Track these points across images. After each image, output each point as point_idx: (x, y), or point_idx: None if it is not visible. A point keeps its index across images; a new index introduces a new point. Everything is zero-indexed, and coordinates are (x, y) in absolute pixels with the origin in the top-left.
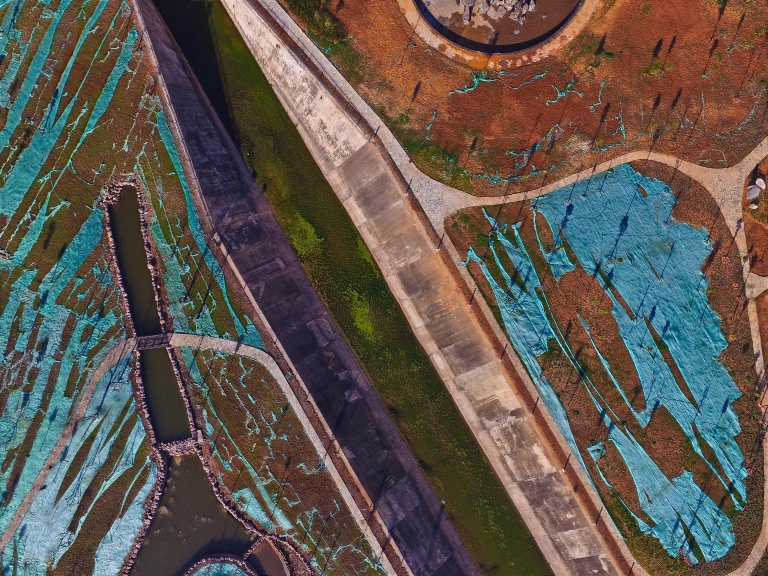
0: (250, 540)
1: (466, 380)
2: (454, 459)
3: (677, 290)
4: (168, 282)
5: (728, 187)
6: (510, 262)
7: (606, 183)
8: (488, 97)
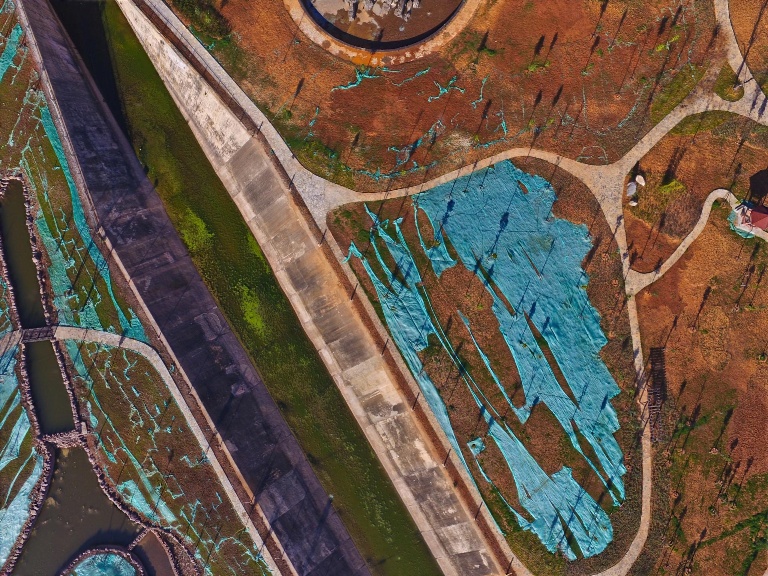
0: (136, 532)
1: (352, 375)
2: (342, 453)
3: (557, 286)
4: (53, 276)
5: (608, 184)
6: (391, 258)
7: (487, 179)
8: (371, 93)
